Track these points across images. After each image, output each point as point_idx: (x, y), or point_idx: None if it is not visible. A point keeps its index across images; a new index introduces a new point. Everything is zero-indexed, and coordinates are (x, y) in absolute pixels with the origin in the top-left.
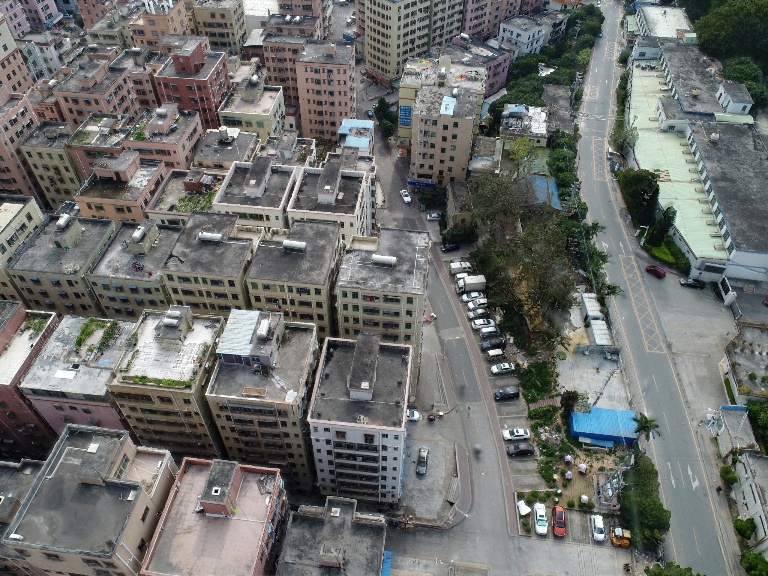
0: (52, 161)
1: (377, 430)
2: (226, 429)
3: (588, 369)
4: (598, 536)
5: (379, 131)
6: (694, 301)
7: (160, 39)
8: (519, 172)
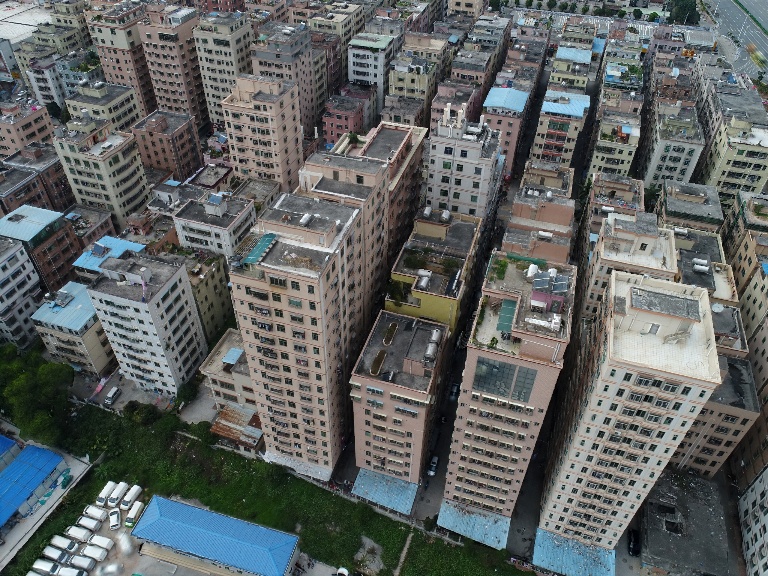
0: None
1: None
2: (437, 5)
3: None
4: None
5: None
6: None
7: None
8: None
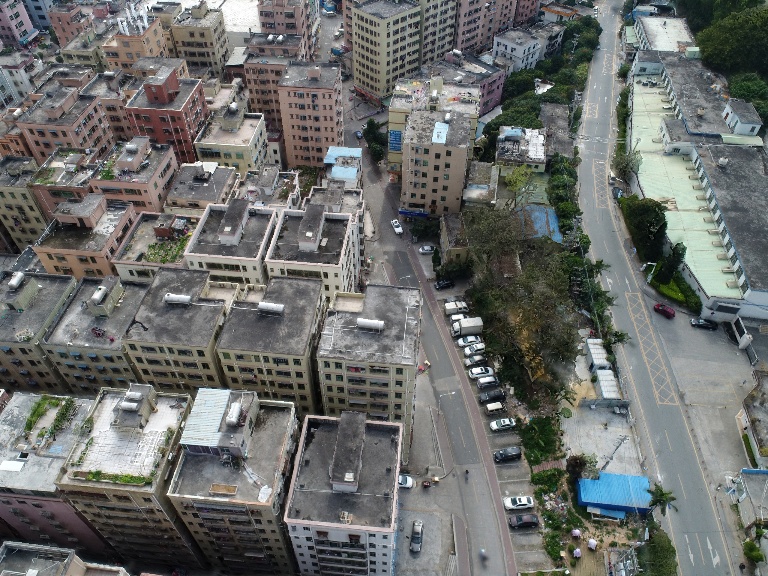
0: (15, 200)
1: (363, 530)
2: (194, 524)
3: (595, 425)
4: None
5: (369, 154)
6: (706, 344)
7: (135, 62)
8: (516, 201)
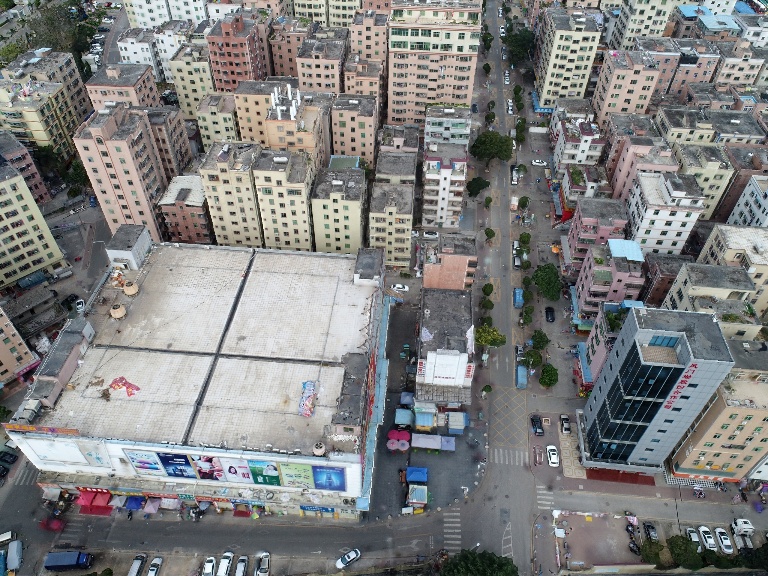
0: None
1: None
2: None
3: None
4: (98, 2)
5: None
6: None
7: None
8: None
